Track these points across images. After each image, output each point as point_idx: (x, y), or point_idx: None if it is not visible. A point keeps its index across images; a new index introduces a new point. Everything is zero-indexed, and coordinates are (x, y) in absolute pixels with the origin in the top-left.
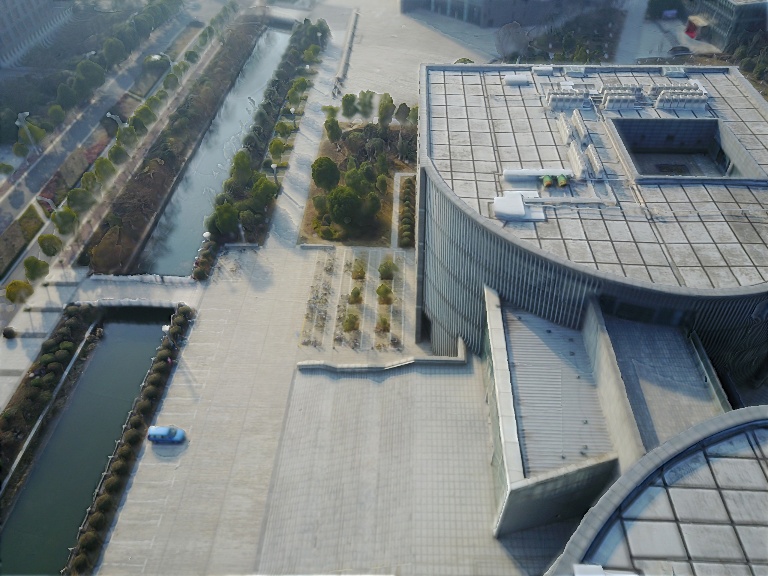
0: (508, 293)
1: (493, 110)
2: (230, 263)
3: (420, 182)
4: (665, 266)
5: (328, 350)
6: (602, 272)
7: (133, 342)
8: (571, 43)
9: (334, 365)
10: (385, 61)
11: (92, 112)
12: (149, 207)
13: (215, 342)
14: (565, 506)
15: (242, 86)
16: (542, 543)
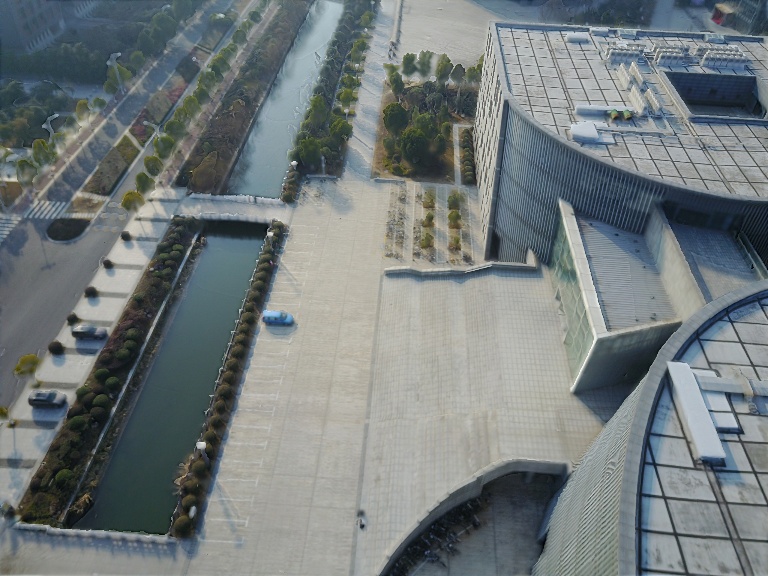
0: (581, 204)
1: (559, 61)
2: (313, 190)
3: (503, 113)
4: (718, 181)
5: (409, 261)
6: (668, 181)
7: (230, 252)
8: (609, 21)
9: (419, 269)
10: (434, 30)
11: (166, 61)
12: (232, 143)
13: (309, 251)
14: (634, 364)
15: (299, 47)
16: (610, 398)
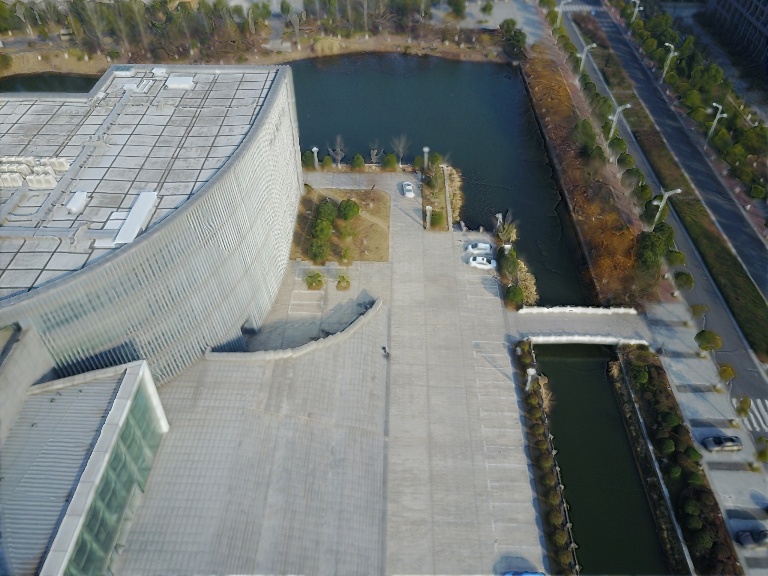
0: None
1: None
2: None
3: None
4: None
5: None
6: None
7: None
8: None
9: None
10: None
11: None
12: None
13: None
14: None
15: None
16: None
